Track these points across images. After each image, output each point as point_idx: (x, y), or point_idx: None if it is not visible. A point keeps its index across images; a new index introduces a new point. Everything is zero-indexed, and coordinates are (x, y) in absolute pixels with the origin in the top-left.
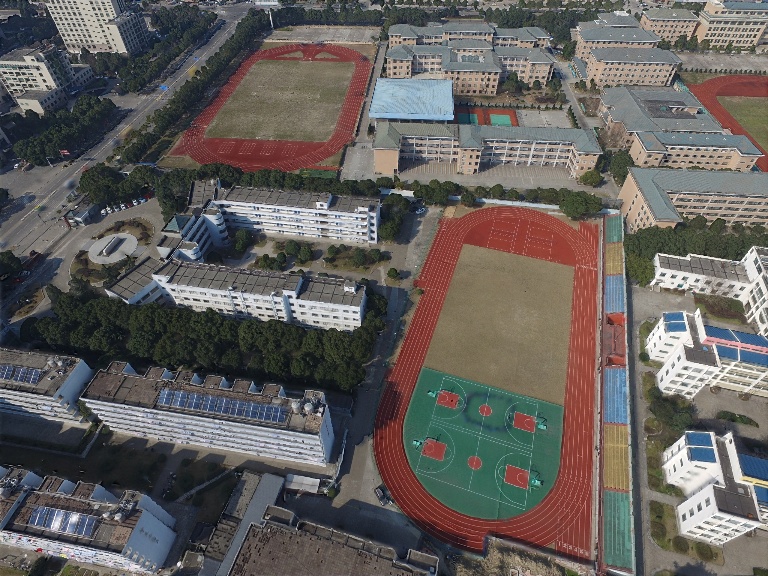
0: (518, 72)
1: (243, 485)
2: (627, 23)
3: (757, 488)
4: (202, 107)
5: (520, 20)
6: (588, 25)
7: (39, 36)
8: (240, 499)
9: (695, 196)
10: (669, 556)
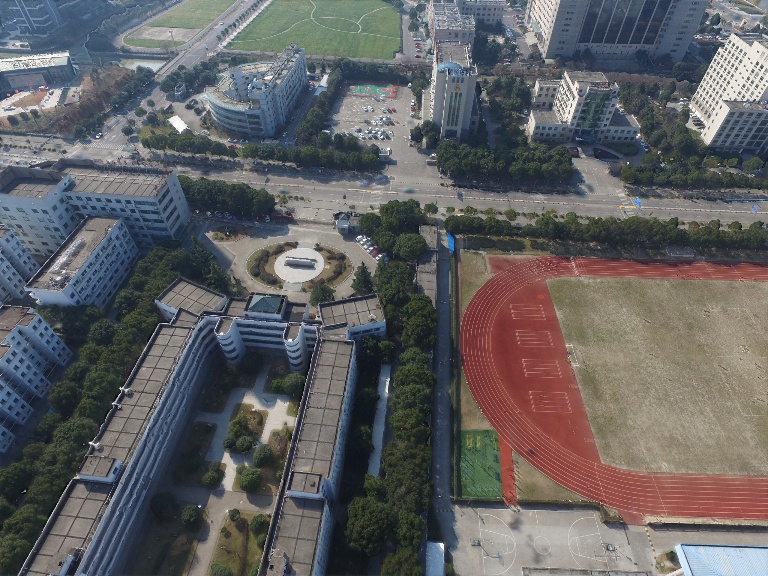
0: None
1: None
2: None
3: None
4: (629, 256)
5: None
6: None
7: (698, 75)
8: None
9: None
10: None
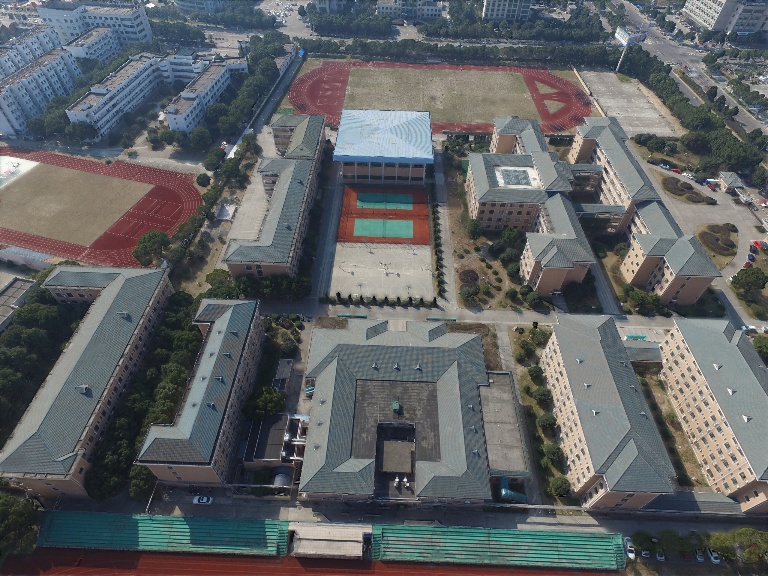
0: None
1: None
2: None
3: None
4: (404, 61)
5: None
6: None
7: None
8: None
9: None
10: None
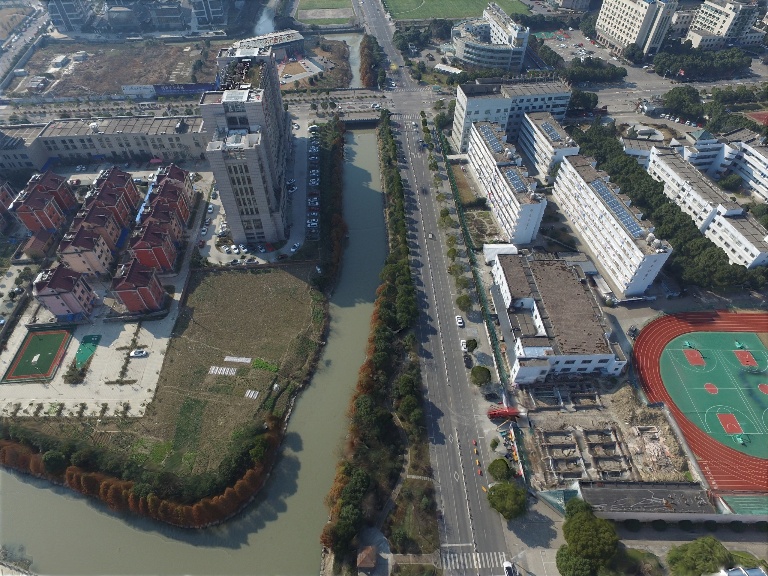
0: None
1: (577, 255)
2: None
3: None
4: None
5: None
6: None
7: None
8: (569, 257)
9: None
10: None
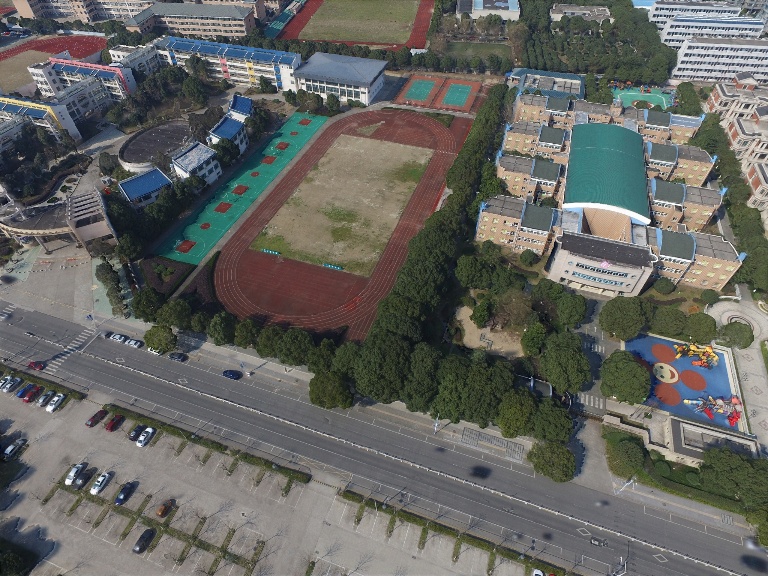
0: None
1: None
2: None
3: None
4: None
5: None
6: None
7: None
8: None
9: (177, 19)
10: None
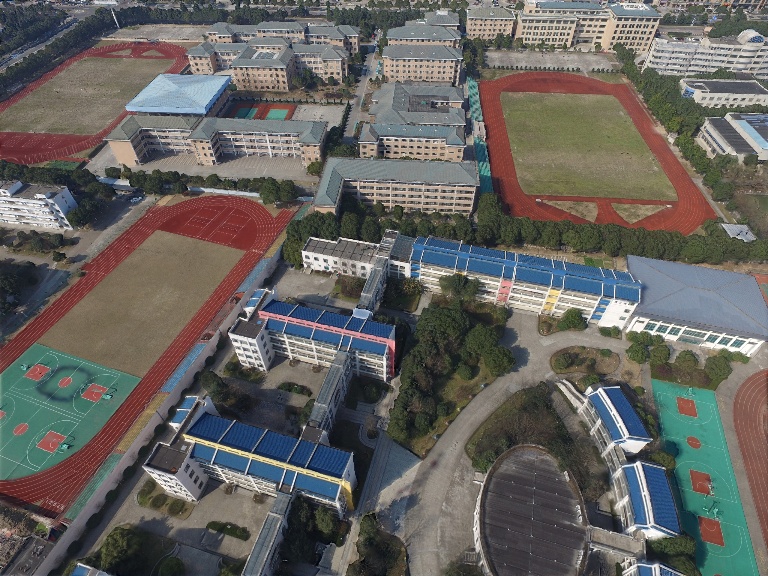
0: (318, 69)
1: None
2: (445, 22)
3: (198, 445)
4: None
5: (356, 19)
6: (410, 24)
7: None
8: None
9: (375, 184)
10: (141, 511)
